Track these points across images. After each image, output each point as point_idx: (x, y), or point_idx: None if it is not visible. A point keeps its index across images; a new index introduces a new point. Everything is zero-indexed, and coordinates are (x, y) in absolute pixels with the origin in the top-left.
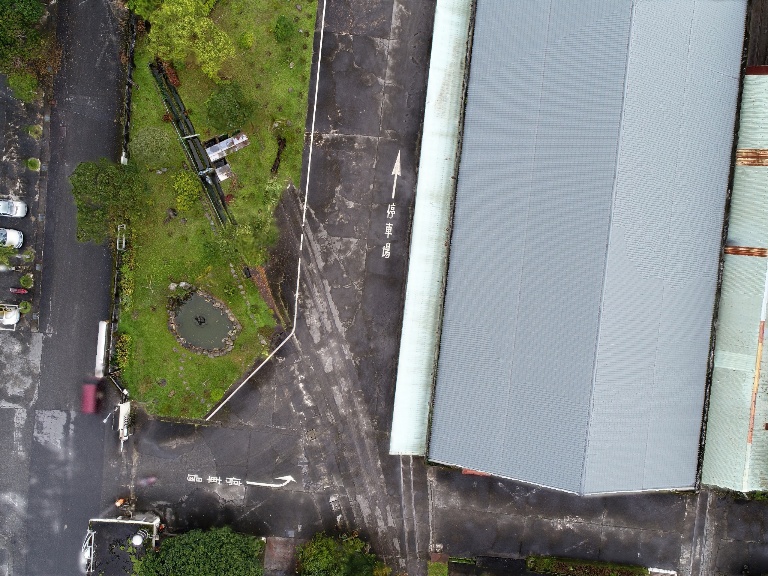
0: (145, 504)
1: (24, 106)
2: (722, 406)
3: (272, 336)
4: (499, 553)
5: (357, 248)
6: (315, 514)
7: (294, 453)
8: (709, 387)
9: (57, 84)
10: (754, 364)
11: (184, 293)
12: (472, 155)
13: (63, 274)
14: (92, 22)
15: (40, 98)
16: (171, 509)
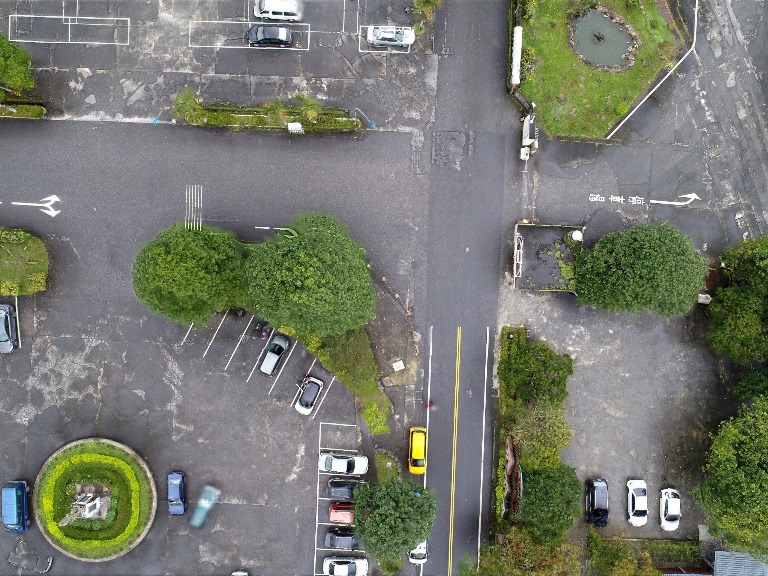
0: None
1: None
2: None
3: (671, 52)
4: None
5: None
6: (721, 232)
7: (697, 170)
8: None
9: None
10: None
11: (586, 6)
12: None
13: None
14: None
15: None
16: None
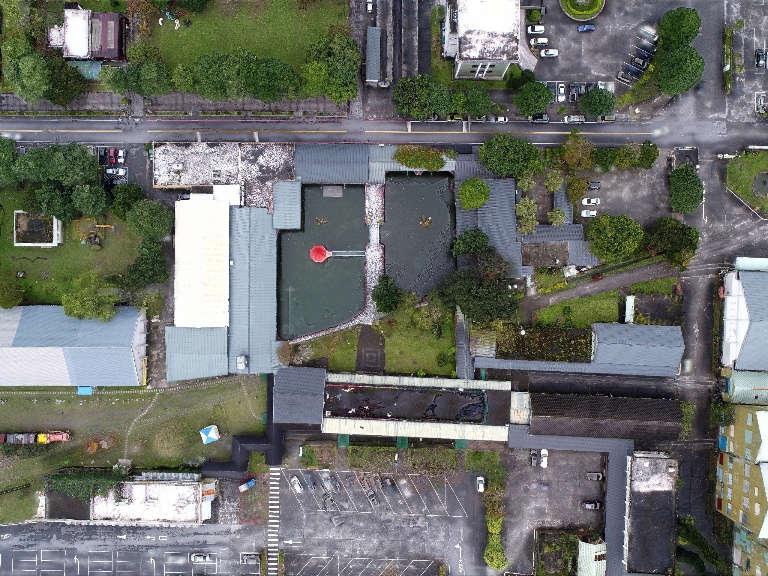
0: None
1: None
2: (763, 379)
3: (761, 211)
4: (683, 304)
5: None
6: None
7: (716, 222)
8: None
9: None
10: None
11: None
12: None
13: None
14: None
15: None
16: None
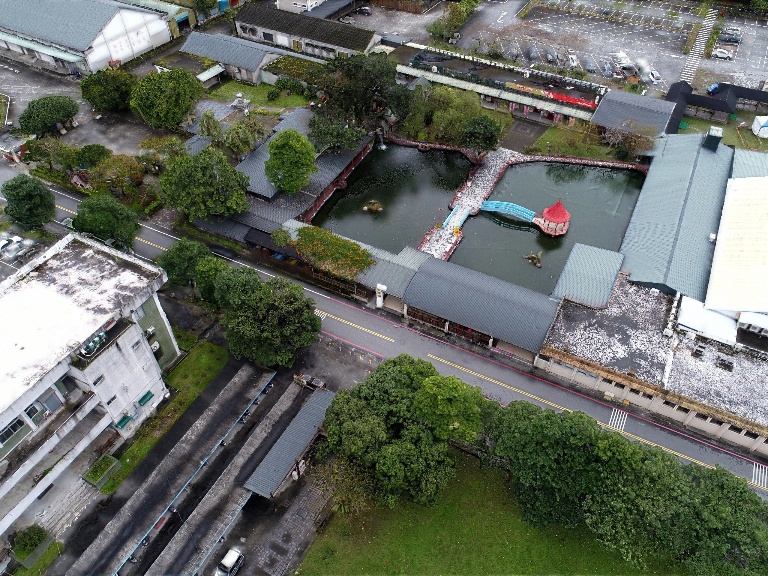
0: None
1: None
2: None
3: None
4: None
5: (5, 76)
6: None
7: None
8: (140, 6)
9: None
10: (145, 0)
11: None
12: (5, 24)
13: None
14: None
15: None
16: None
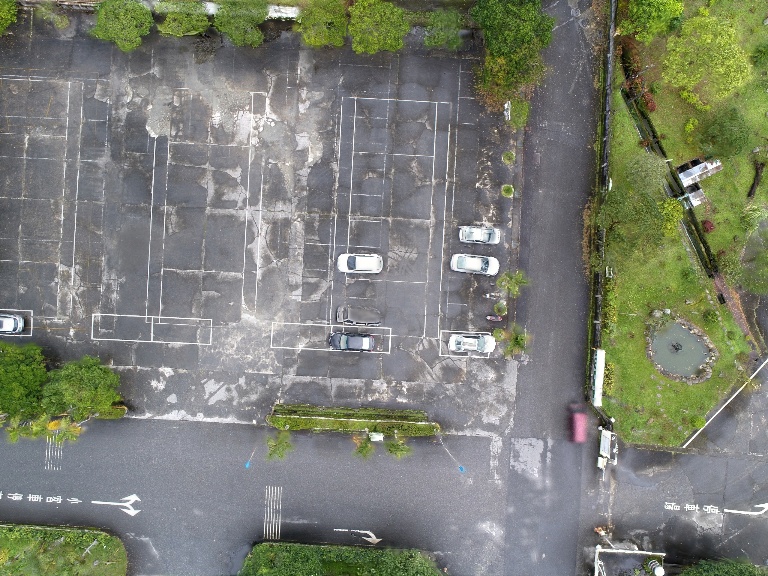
0: (622, 532)
1: (497, 132)
2: None
3: (748, 362)
4: None
5: None
6: None
7: None
8: None
9: (530, 110)
10: None
11: None
12: None
13: (538, 301)
14: (566, 47)
15: (513, 124)
16: (648, 537)
